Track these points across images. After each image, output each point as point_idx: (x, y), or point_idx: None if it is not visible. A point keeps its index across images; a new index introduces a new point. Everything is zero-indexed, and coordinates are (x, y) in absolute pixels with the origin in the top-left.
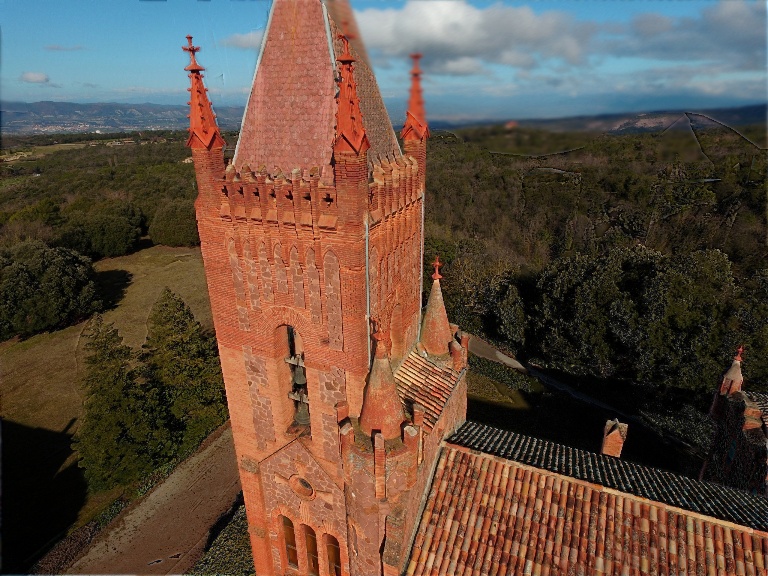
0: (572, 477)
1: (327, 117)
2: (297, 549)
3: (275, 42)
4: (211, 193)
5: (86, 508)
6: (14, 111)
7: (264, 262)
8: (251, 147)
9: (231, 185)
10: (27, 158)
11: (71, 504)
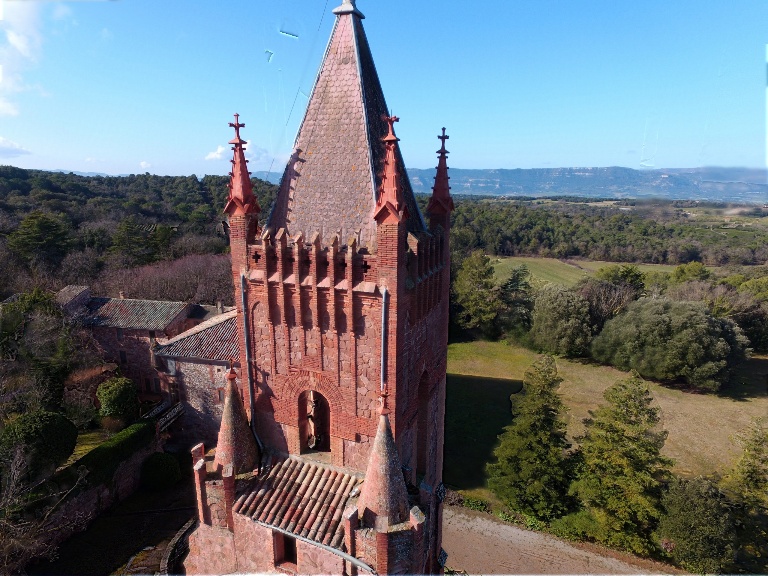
0: None
1: None
2: None
3: None
4: None
5: (482, 491)
6: (754, 183)
7: None
8: None
9: None
10: (745, 228)
11: (484, 482)
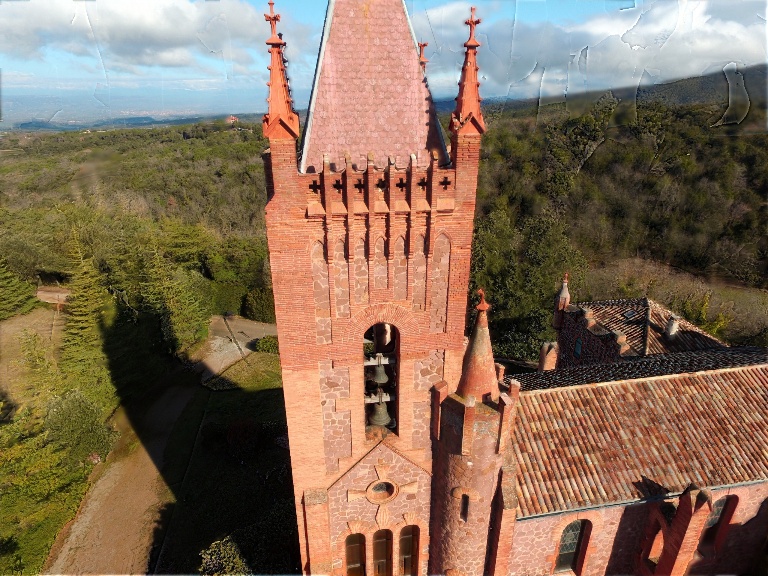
0: (576, 385)
1: (416, 101)
2: (367, 562)
3: (344, 19)
4: (294, 191)
5: None
6: None
7: (359, 260)
8: (327, 135)
9: (329, 179)
10: None
11: None
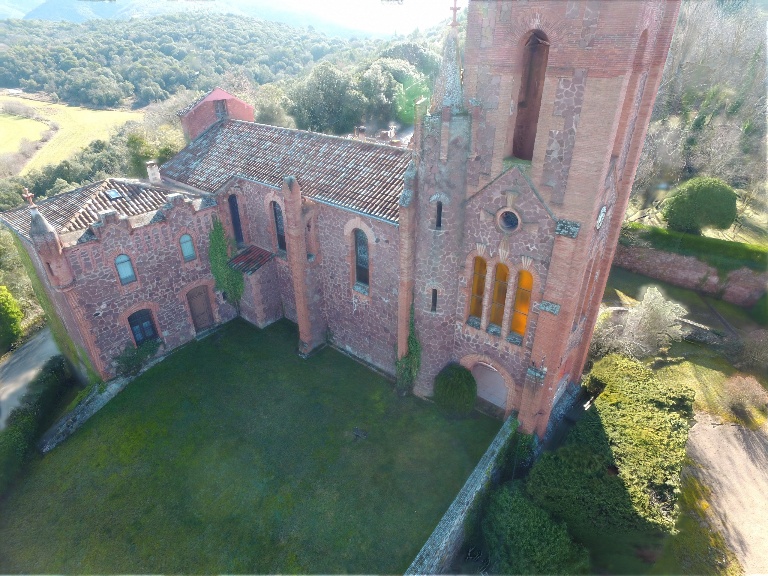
0: None
1: None
2: None
3: None
4: None
5: None
6: None
7: None
8: None
9: None
10: None
11: None
